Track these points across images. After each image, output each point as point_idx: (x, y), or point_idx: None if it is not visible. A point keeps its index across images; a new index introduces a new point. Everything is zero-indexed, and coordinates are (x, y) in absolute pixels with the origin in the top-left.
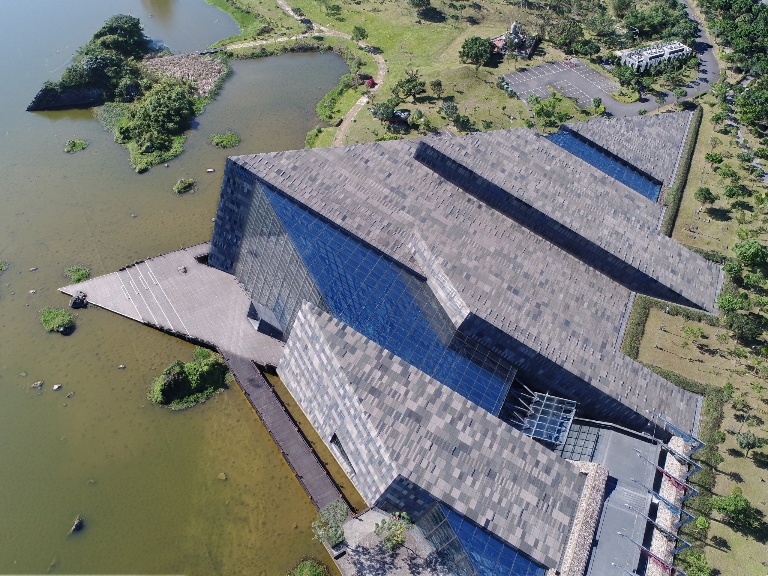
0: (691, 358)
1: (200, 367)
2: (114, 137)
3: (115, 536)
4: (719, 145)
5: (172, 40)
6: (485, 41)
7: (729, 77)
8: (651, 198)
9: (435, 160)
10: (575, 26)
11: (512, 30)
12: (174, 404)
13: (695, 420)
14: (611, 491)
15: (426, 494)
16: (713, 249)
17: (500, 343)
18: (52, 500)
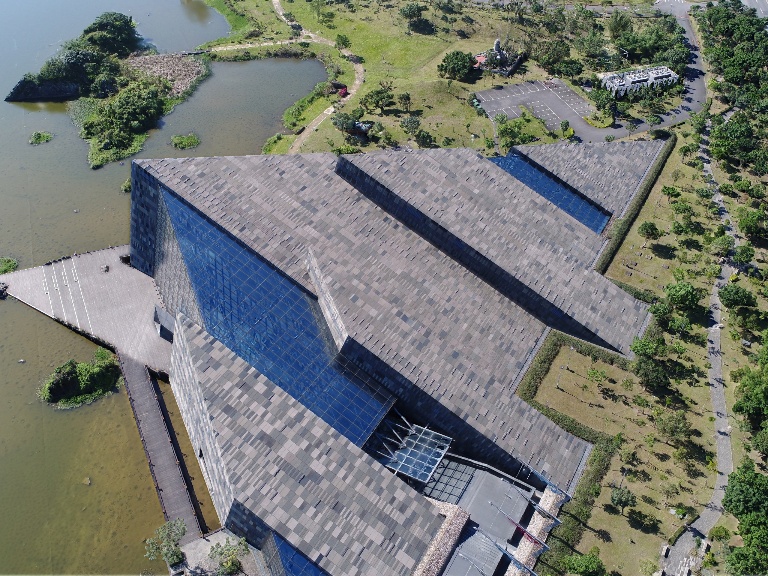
0: (591, 402)
1: (92, 368)
2: (79, 132)
3: None
4: (682, 178)
5: (162, 39)
6: (466, 56)
7: (714, 107)
8: (597, 229)
9: (354, 176)
10: (562, 45)
11: (495, 46)
12: (61, 403)
13: (578, 469)
14: (468, 537)
15: (261, 522)
16: (647, 288)
17: (379, 370)
18: None
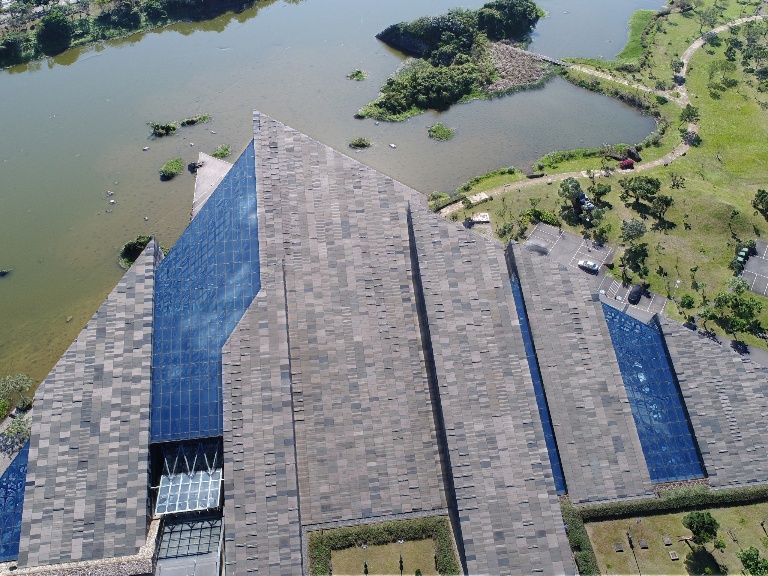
0: None
1: None
2: (384, 84)
3: (2, 294)
4: None
5: (547, 38)
6: None
7: None
8: (670, 476)
9: (411, 228)
10: None
11: None
12: (124, 260)
13: None
14: None
15: None
16: None
17: None
18: (20, 252)
